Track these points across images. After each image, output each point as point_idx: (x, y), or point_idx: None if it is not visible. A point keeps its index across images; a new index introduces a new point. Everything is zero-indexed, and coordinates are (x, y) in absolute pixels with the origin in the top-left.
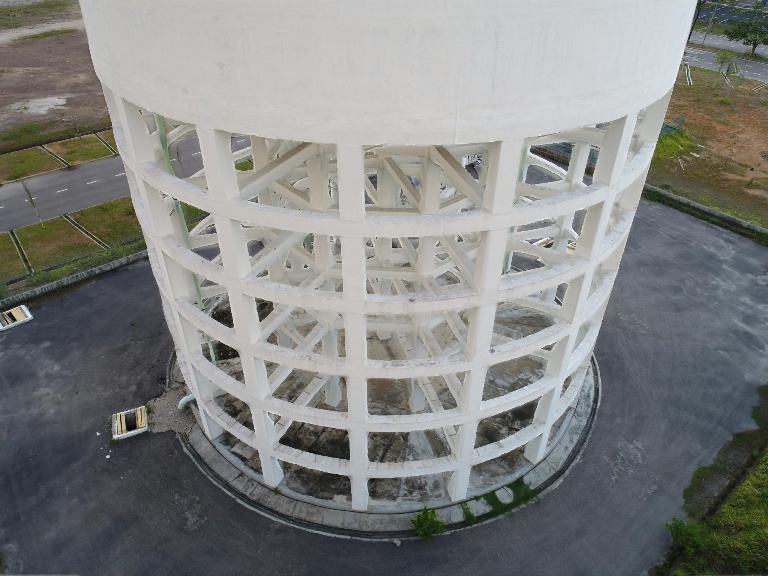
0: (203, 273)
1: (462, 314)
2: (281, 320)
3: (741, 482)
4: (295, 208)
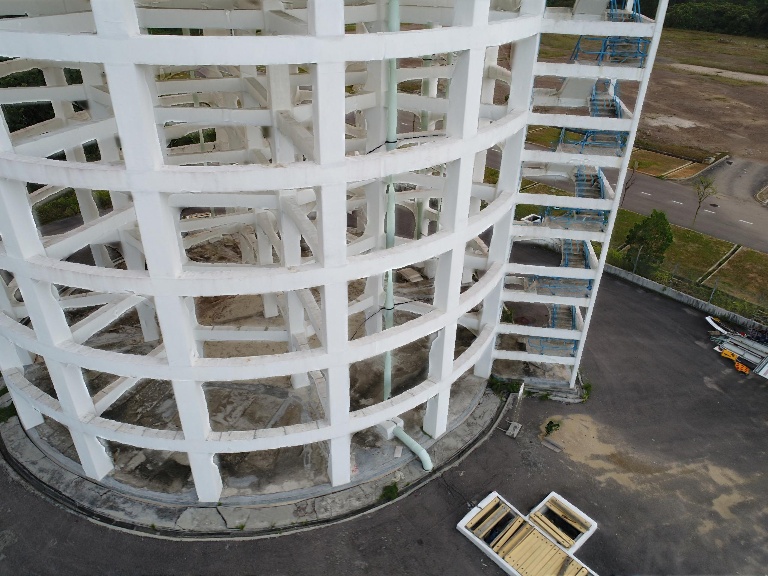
0: None
1: (308, 374)
2: None
3: None
4: None
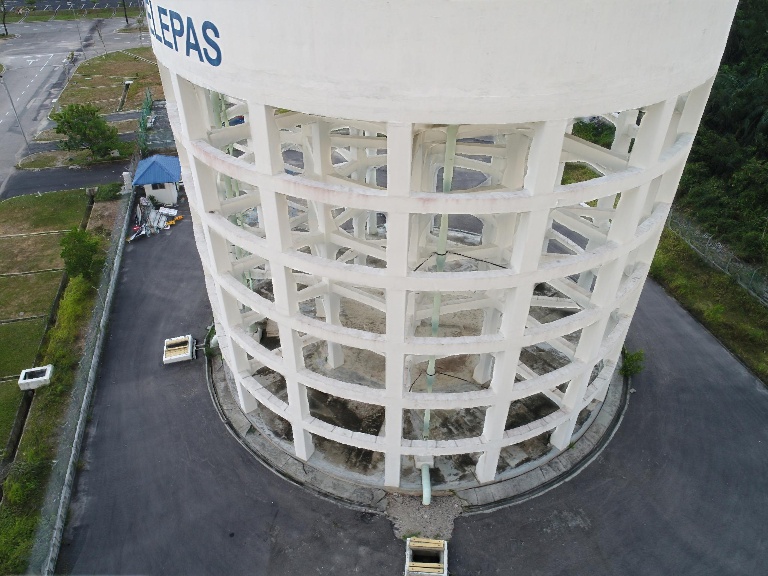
0: (601, 261)
1: None
2: None
3: None
4: None
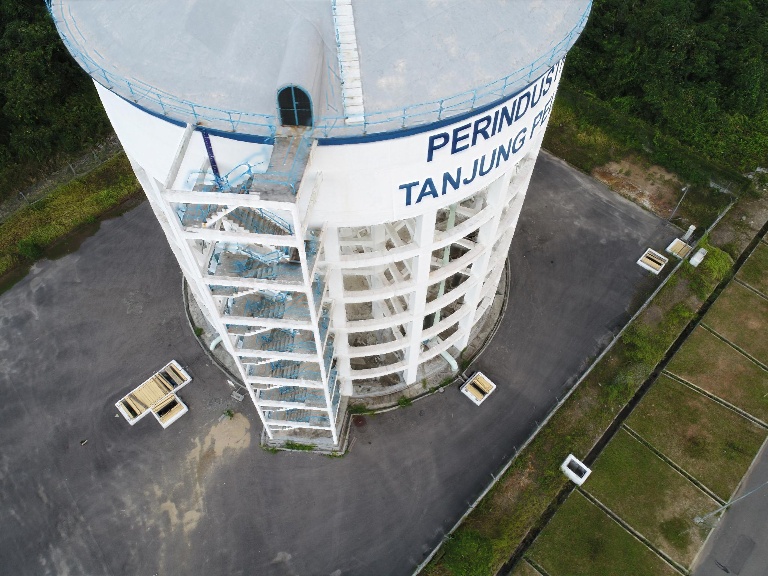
0: None
1: None
2: None
3: (139, 190)
4: None
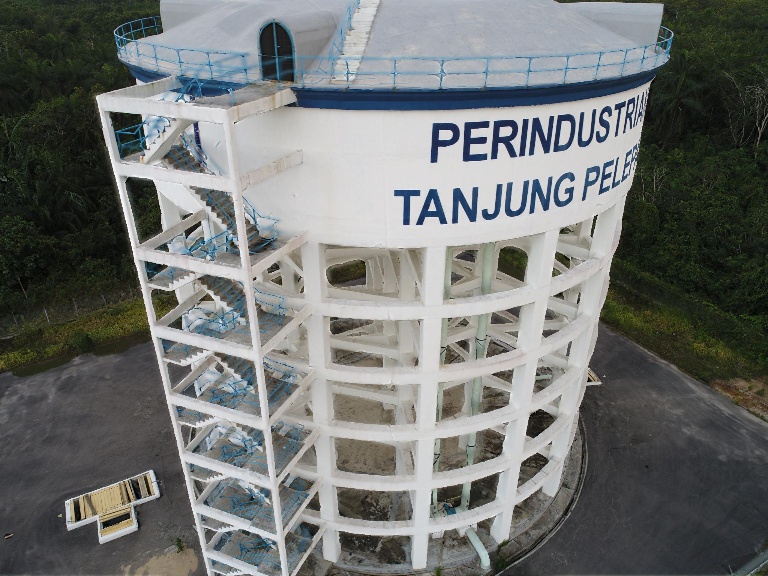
0: None
1: None
2: None
3: None
4: None
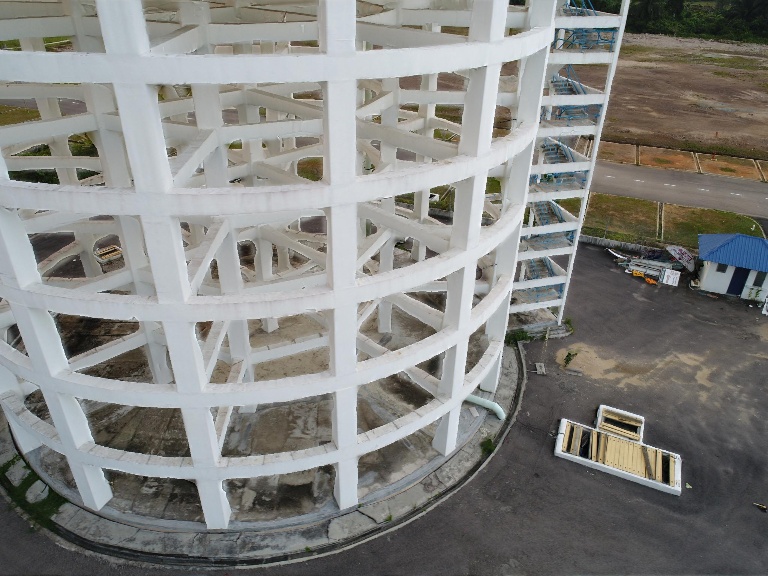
0: None
1: None
2: (29, 167)
3: None
4: (272, 150)
